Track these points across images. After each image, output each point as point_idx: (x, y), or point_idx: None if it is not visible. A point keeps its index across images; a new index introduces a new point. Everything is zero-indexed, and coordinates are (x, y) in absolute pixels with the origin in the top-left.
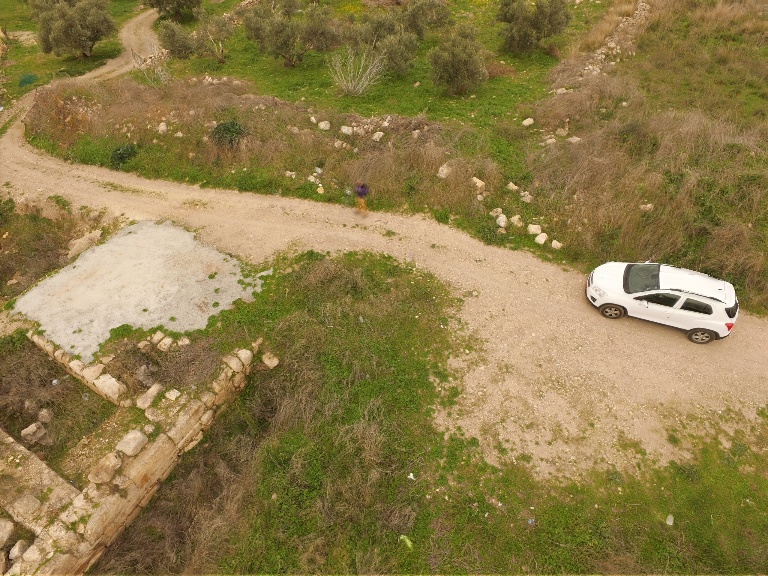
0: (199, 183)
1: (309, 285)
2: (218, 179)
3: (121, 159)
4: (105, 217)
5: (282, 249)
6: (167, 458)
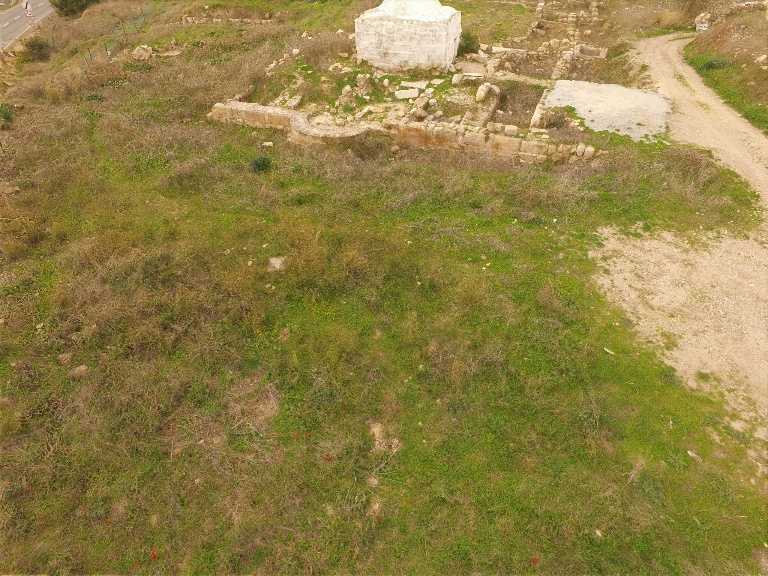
0: (727, 100)
1: (671, 153)
2: (742, 103)
3: (709, 67)
4: (649, 84)
5: (700, 145)
6: (511, 151)
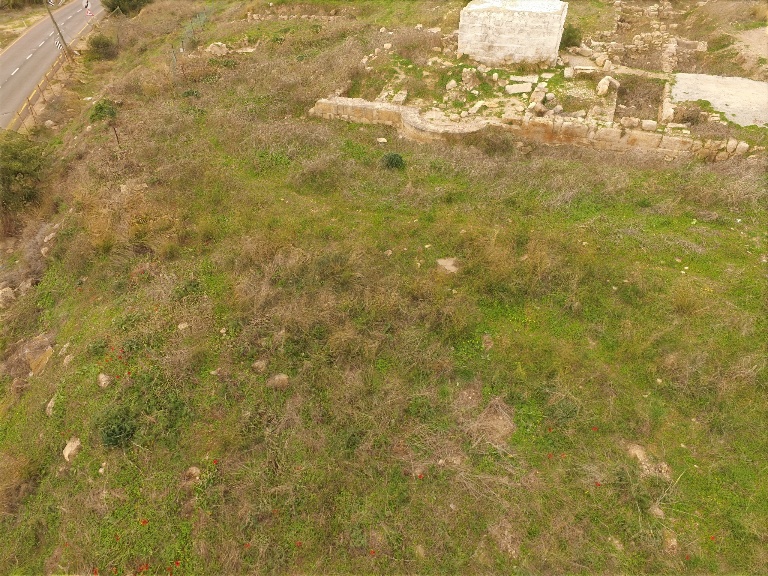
0: None
1: None
2: None
3: None
4: None
5: None
6: (649, 147)
